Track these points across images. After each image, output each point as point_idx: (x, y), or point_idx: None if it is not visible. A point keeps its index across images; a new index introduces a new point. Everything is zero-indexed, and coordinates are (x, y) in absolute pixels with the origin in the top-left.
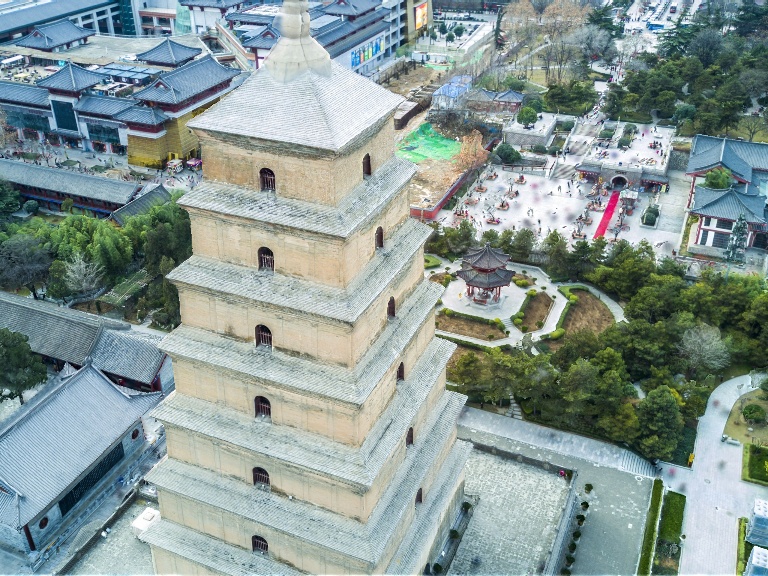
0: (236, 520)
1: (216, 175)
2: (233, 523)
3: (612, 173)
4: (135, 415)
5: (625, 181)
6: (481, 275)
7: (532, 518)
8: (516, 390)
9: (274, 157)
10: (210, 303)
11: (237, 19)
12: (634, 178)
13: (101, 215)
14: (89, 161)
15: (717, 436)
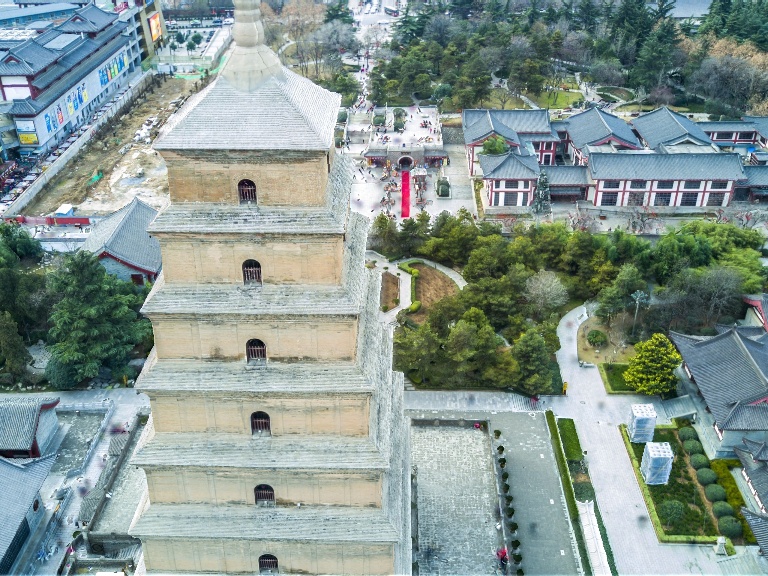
0: (240, 546)
1: (186, 195)
2: (236, 550)
3: (398, 155)
4: (36, 484)
5: (411, 160)
6: None
7: (469, 472)
8: (408, 363)
9: (255, 167)
10: (192, 329)
11: None
12: (418, 156)
13: None
14: None
15: (575, 364)
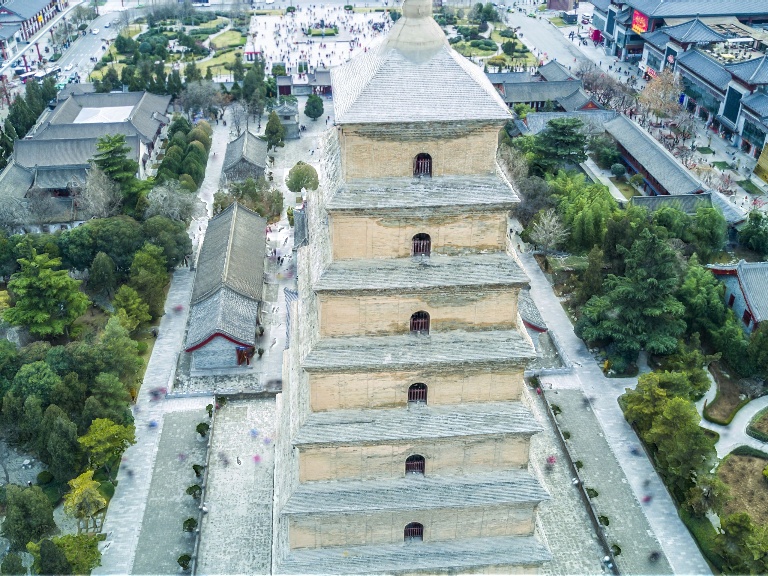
0: None
1: None
2: None
3: None
4: None
5: None
6: None
7: None
8: None
9: None
10: None
11: None
12: None
13: None
14: (724, 155)
15: None
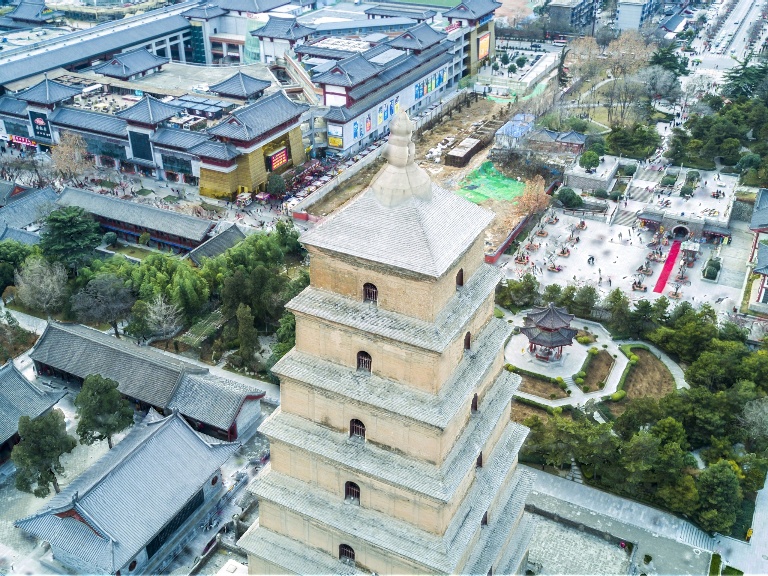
0: None
1: (322, 284)
2: None
3: (674, 223)
4: (216, 464)
5: (687, 231)
6: (544, 333)
7: None
8: (578, 456)
9: (378, 275)
10: (309, 395)
11: (306, 52)
12: (696, 229)
13: (176, 249)
14: (162, 190)
15: None
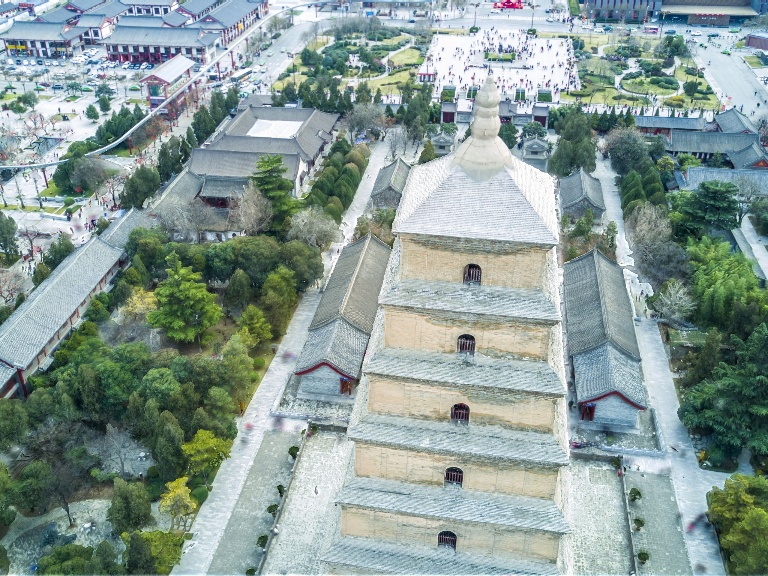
0: None
1: None
2: None
3: None
4: None
5: None
6: None
7: None
8: None
9: None
10: None
11: None
12: None
13: None
14: None
15: None
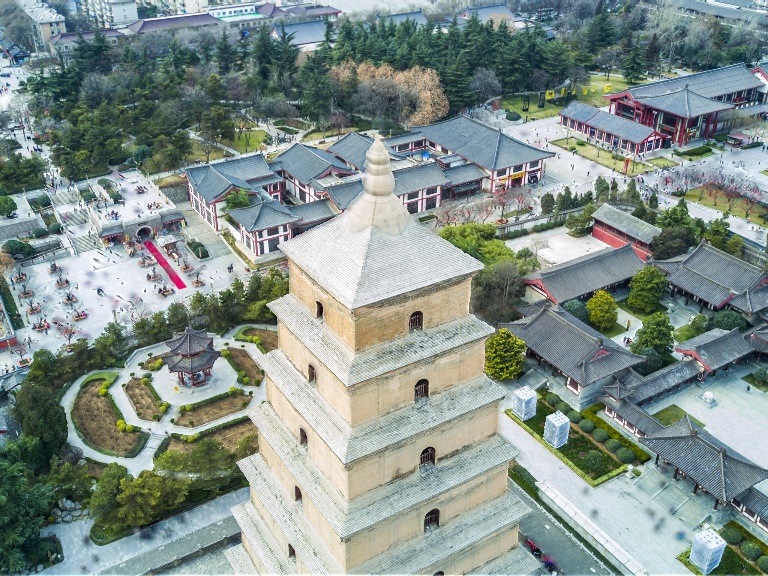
0: None
1: (368, 342)
2: None
3: (135, 227)
4: None
5: (149, 230)
6: (194, 359)
7: None
8: None
9: (424, 299)
10: (380, 461)
11: None
12: (157, 224)
13: None
14: None
15: None
